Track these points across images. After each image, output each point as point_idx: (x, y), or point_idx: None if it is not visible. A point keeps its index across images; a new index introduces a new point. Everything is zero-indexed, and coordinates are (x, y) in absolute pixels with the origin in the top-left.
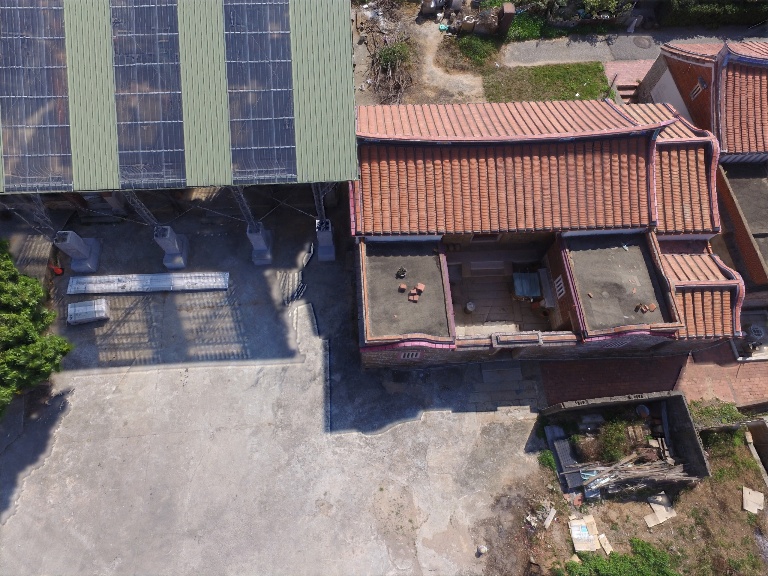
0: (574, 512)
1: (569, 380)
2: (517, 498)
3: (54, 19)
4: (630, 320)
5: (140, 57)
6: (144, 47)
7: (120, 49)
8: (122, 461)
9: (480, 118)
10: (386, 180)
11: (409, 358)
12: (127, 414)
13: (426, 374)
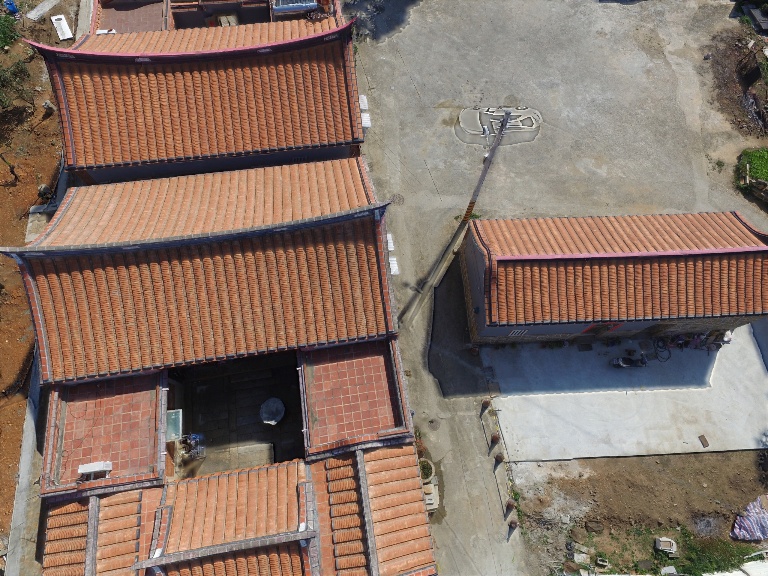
0: (765, 46)
1: None
2: (727, 37)
3: None
4: None
5: None
6: None
7: None
8: (469, 6)
9: None
10: None
11: None
12: None
13: None
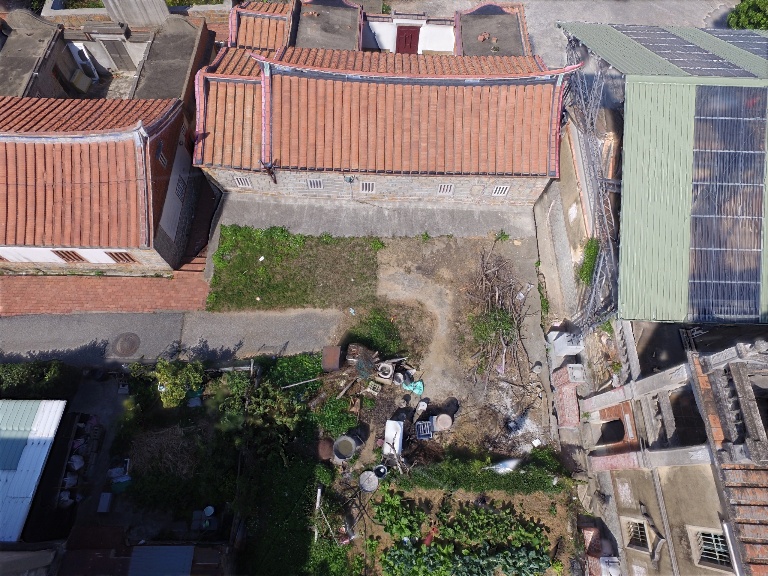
0: None
1: None
2: None
3: None
4: (326, 10)
5: None
6: None
7: None
8: None
9: (421, 142)
10: None
11: None
12: None
13: None
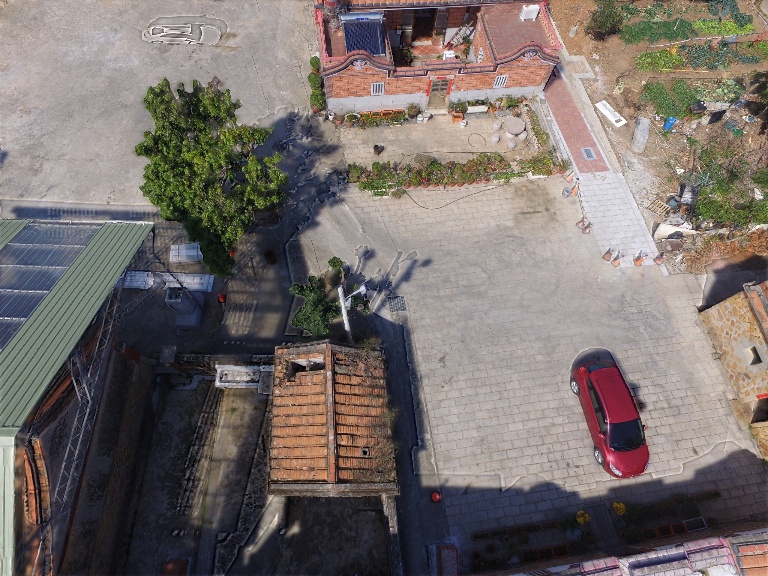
0: None
1: None
2: None
3: None
4: None
5: None
6: None
7: None
8: None
9: None
10: None
11: None
12: None
13: None
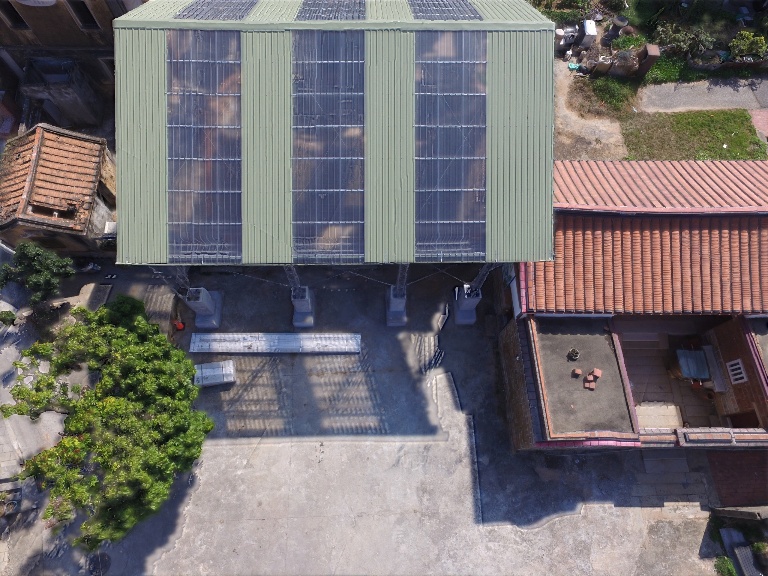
0: None
1: (741, 474)
2: None
3: (229, 74)
4: None
5: (320, 118)
6: (325, 107)
7: (299, 109)
8: (258, 547)
9: (648, 179)
10: (561, 252)
11: (574, 447)
12: (261, 493)
13: (582, 460)
